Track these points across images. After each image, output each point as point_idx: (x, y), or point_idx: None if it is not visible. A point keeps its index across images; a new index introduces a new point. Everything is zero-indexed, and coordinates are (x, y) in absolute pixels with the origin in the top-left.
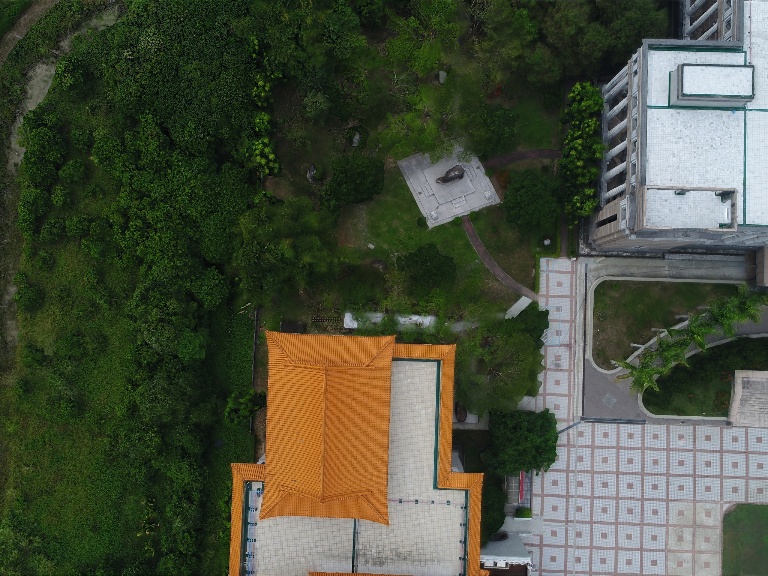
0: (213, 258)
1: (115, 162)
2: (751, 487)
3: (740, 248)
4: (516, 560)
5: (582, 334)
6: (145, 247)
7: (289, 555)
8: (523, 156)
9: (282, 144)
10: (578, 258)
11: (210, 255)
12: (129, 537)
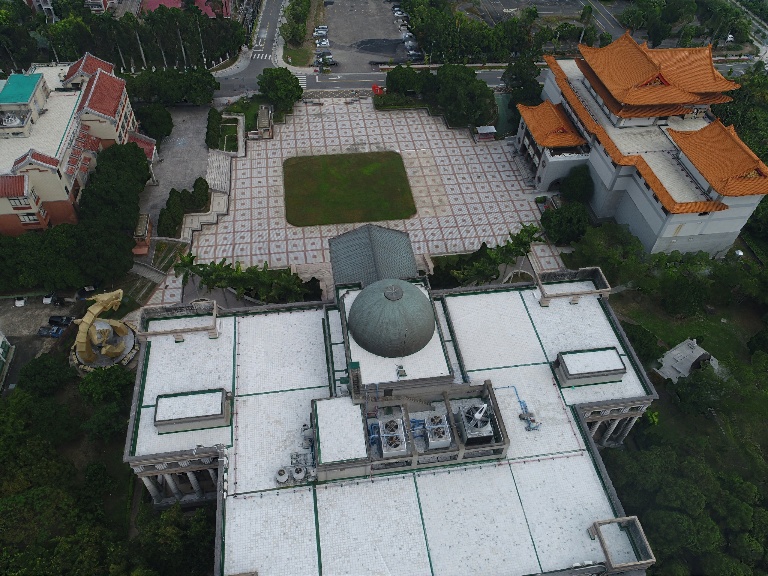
0: None
1: None
2: (403, 227)
3: None
4: (559, 157)
5: None
6: None
7: None
8: None
9: None
10: None
11: None
12: None
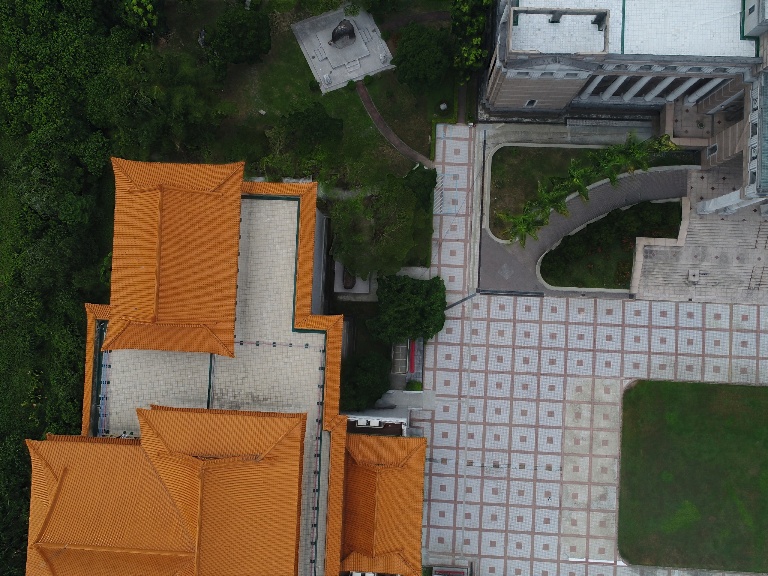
0: (99, 122)
1: (3, 26)
2: (653, 363)
3: (642, 107)
4: (390, 419)
5: (479, 203)
6: (32, 112)
7: (143, 398)
8: (421, 19)
9: (174, 9)
10: (476, 124)
11: (94, 117)
12: (16, 409)
